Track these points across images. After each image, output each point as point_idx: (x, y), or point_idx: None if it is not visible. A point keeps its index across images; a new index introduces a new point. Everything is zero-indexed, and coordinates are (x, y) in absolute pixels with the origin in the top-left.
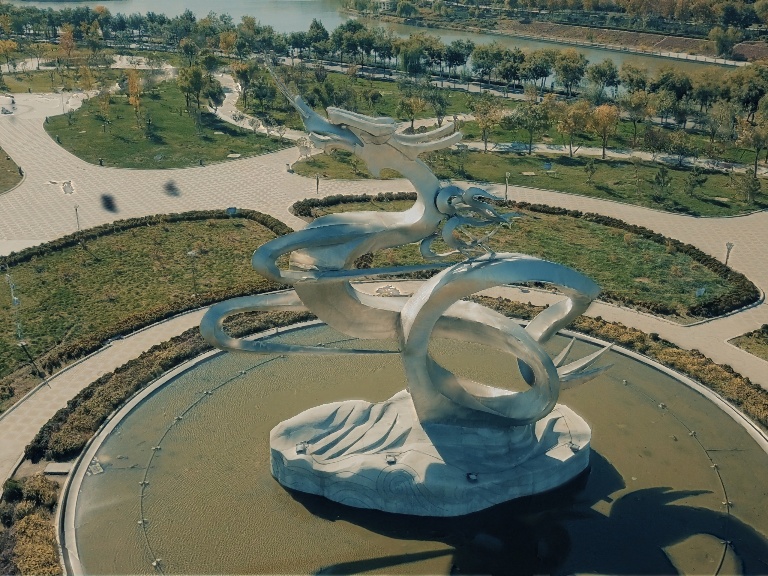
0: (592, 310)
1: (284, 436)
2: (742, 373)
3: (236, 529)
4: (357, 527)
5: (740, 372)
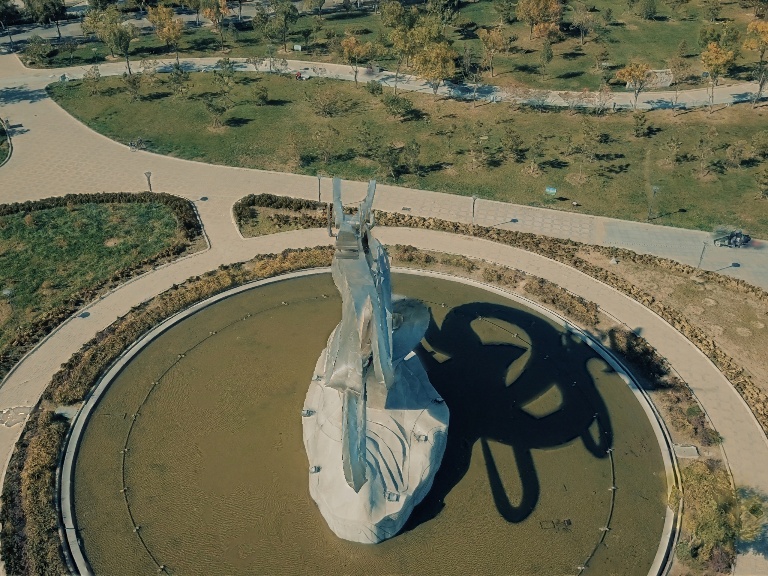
0: (153, 286)
1: (374, 507)
2: (295, 248)
3: (452, 572)
4: (454, 490)
5: (293, 248)
